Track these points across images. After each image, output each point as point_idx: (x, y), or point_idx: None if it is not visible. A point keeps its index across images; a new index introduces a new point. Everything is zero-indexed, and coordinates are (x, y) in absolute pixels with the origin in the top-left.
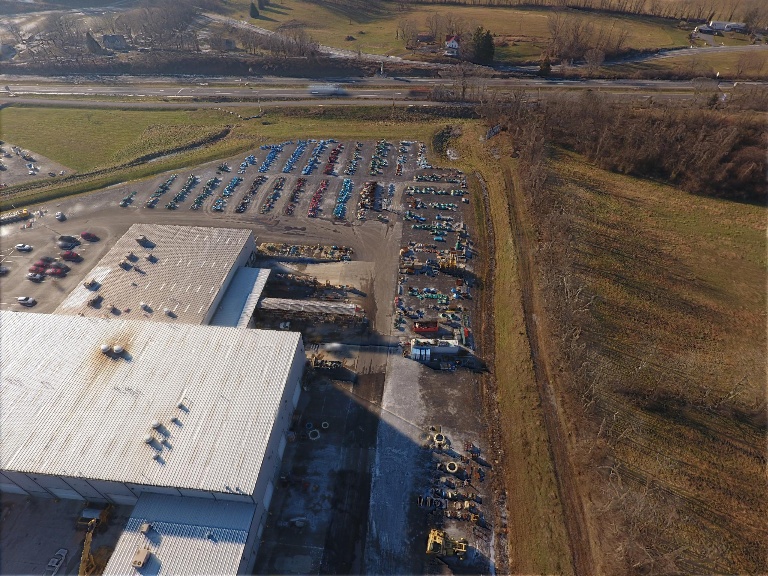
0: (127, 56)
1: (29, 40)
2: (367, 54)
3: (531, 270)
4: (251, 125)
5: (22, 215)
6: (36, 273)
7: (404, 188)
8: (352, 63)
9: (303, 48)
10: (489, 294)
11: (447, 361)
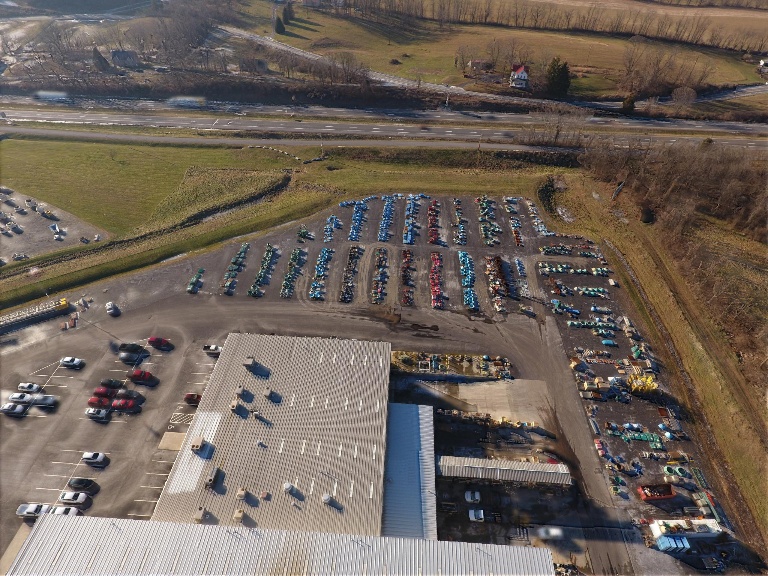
0: (143, 77)
1: (18, 51)
2: (423, 82)
3: (747, 393)
4: (315, 171)
5: (60, 307)
6: (99, 407)
7: (535, 265)
8: (411, 93)
9: (351, 74)
10: (706, 430)
11: (708, 553)
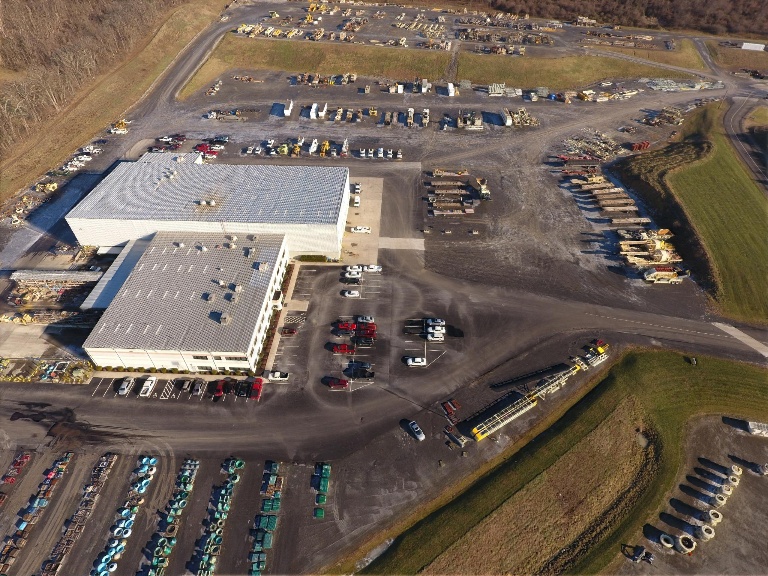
0: None
1: None
2: None
3: None
4: None
5: None
6: None
7: None
8: None
9: None
10: None
11: None
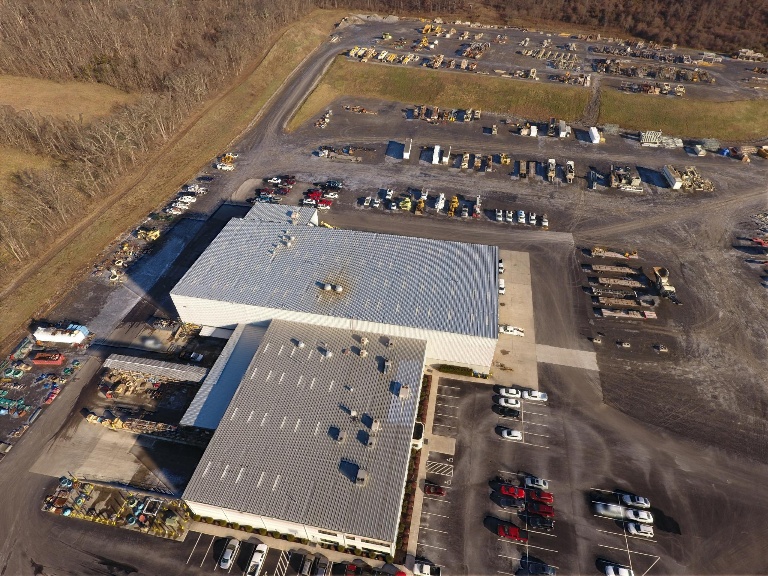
0: None
1: None
2: None
3: None
4: None
5: None
6: None
7: None
8: None
9: None
10: None
11: (60, 328)
